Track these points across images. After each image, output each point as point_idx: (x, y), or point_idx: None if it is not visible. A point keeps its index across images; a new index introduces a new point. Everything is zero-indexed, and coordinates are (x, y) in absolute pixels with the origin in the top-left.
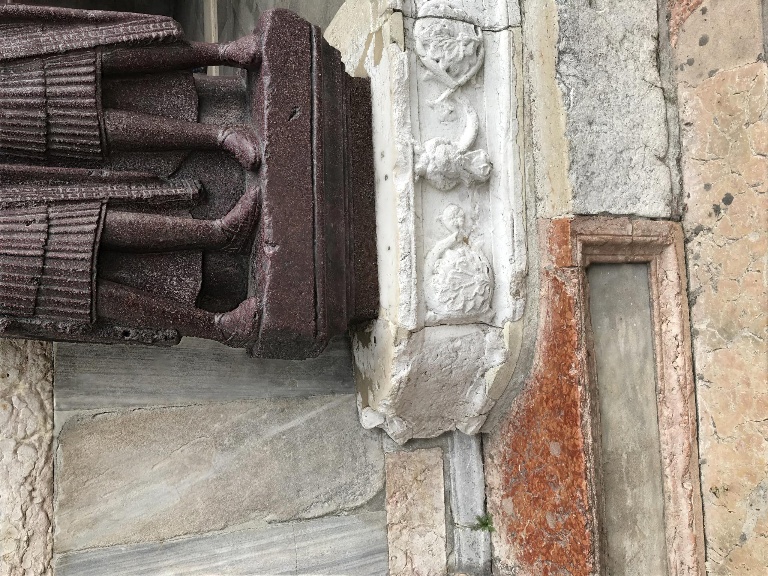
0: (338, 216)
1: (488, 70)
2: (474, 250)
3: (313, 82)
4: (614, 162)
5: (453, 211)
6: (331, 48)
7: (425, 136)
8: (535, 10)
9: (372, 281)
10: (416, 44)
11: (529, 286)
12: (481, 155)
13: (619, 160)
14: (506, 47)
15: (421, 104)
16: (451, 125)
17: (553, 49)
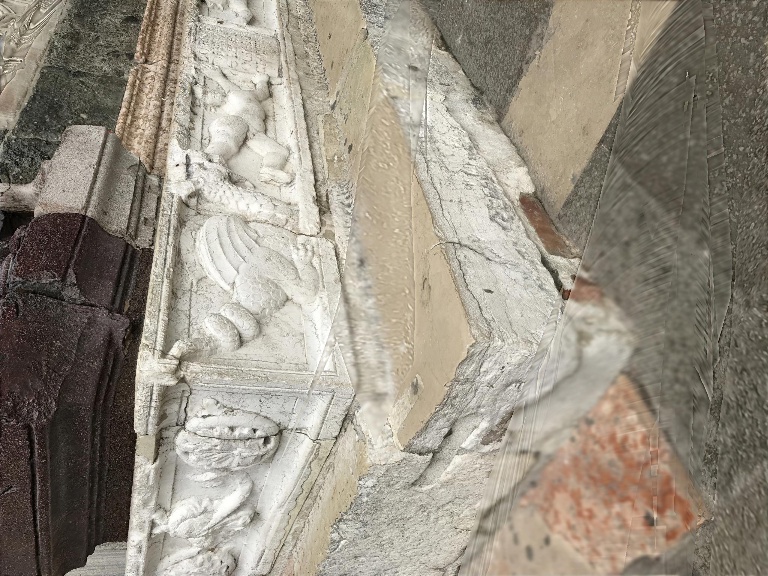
0: (78, 516)
1: (279, 457)
2: (218, 556)
3: (35, 465)
4: (372, 575)
5: (199, 540)
6: (74, 412)
7: (180, 496)
8: (348, 452)
9: (122, 530)
10: (176, 450)
11: (269, 575)
12: (239, 521)
13: (380, 574)
14: (305, 454)
15: (179, 478)
16: (216, 489)
17: (338, 511)
